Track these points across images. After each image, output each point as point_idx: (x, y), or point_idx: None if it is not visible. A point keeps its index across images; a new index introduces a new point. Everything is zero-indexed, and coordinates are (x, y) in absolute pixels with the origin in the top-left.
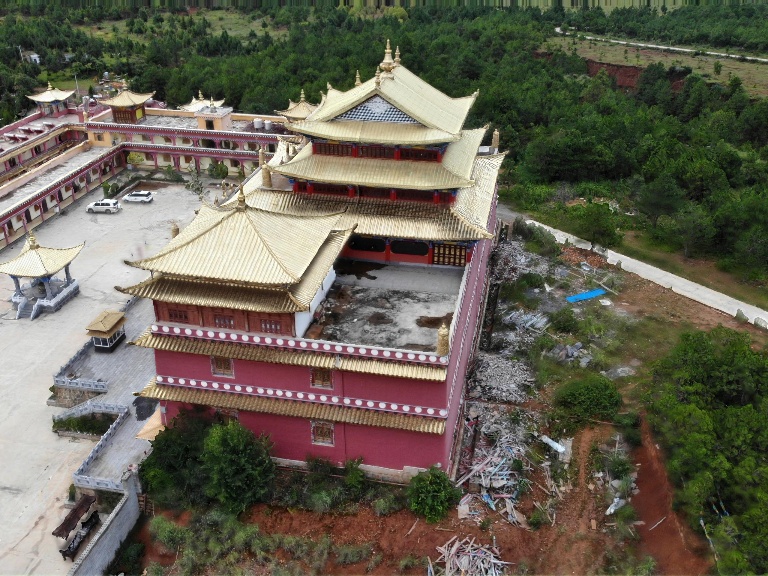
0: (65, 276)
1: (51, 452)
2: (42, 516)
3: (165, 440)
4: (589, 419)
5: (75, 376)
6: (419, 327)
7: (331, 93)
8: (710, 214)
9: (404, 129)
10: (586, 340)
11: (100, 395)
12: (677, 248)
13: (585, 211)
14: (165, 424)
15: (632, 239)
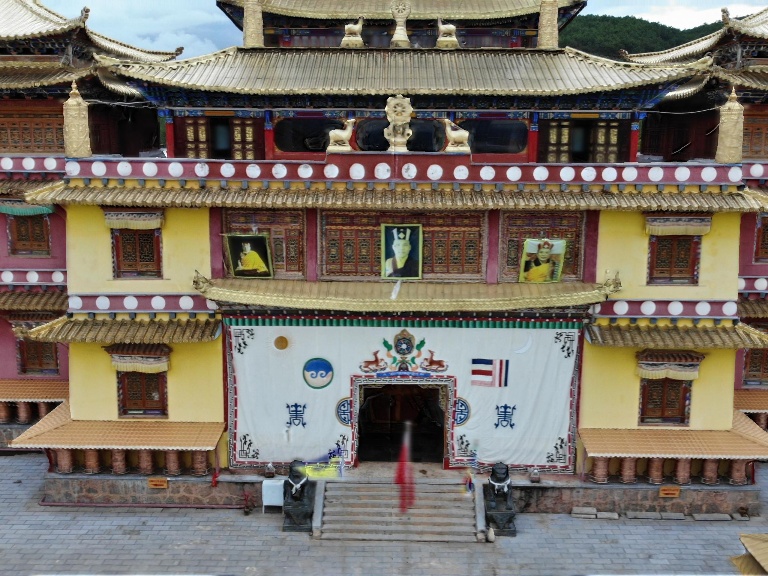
0: None
1: None
2: None
3: None
4: None
5: None
6: None
7: None
8: None
9: None
10: None
11: None
12: None
13: None
14: None
15: None
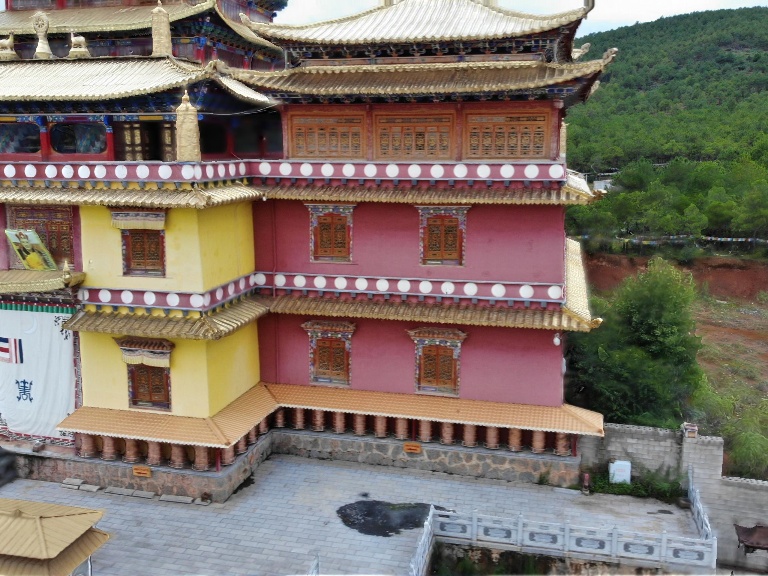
0: None
1: None
2: None
3: None
4: None
5: None
6: None
7: None
8: None
9: None
10: None
11: None
12: None
13: None
14: (562, 402)
15: None
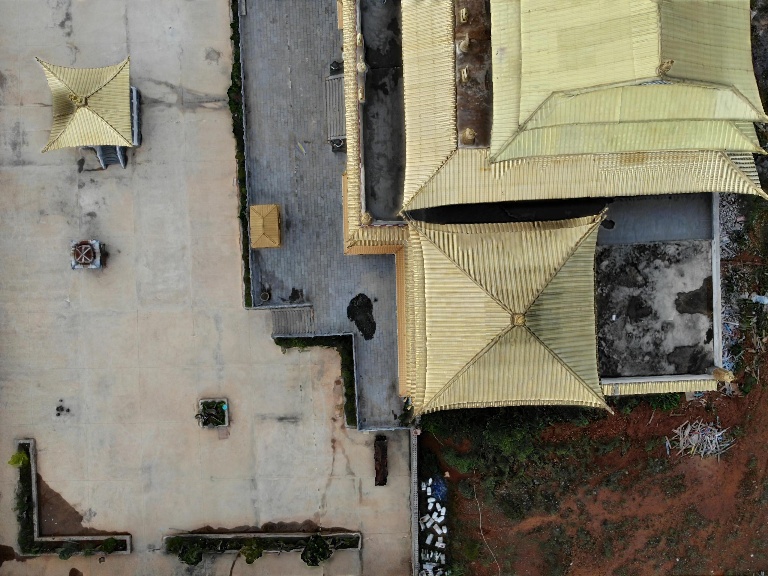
0: (94, 56)
1: (292, 369)
2: (333, 440)
3: (441, 416)
4: None
5: (269, 294)
6: (681, 316)
7: None
8: None
9: (683, 95)
10: None
11: (306, 309)
12: None
13: None
14: None
15: None
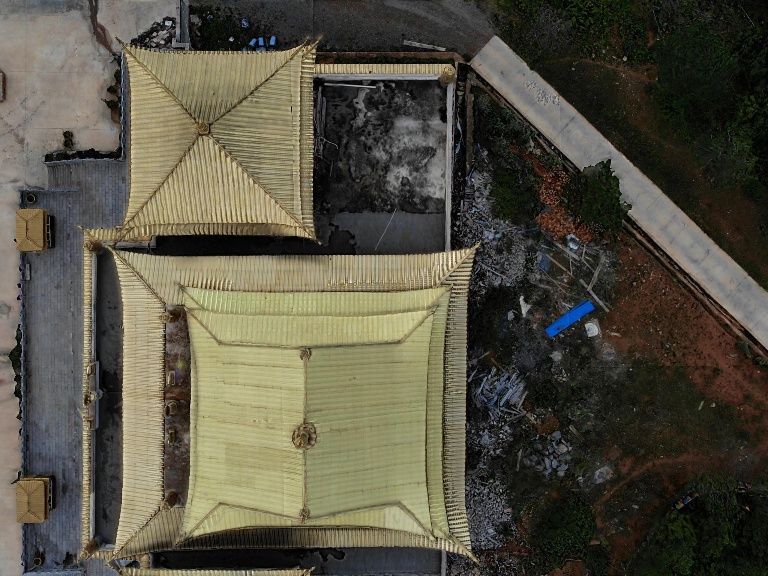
0: None
1: None
2: None
3: None
4: (563, 564)
5: (41, 559)
6: None
7: (197, 333)
8: (763, 85)
9: None
10: (566, 421)
11: None
12: (701, 131)
13: (579, 5)
14: None
15: (642, 98)
